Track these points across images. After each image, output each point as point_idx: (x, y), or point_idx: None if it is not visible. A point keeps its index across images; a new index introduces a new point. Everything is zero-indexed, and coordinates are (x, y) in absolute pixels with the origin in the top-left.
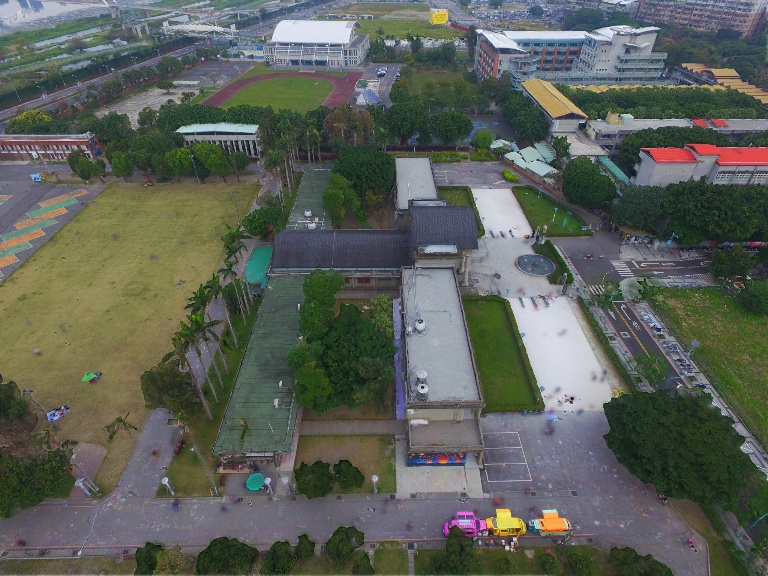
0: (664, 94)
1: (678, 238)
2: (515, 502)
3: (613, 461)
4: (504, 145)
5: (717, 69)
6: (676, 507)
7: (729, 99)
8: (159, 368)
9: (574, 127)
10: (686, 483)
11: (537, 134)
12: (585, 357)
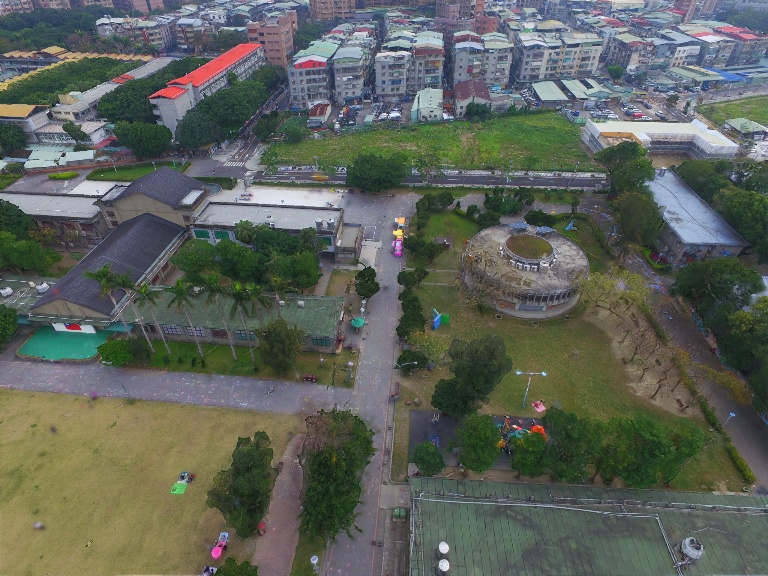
0: (59, 73)
1: (230, 135)
2: (386, 234)
3: (371, 203)
4: (7, 162)
5: (45, 49)
6: (396, 194)
7: (99, 63)
8: (272, 327)
9: (45, 119)
10: (398, 174)
11: (20, 140)
12: (302, 194)
